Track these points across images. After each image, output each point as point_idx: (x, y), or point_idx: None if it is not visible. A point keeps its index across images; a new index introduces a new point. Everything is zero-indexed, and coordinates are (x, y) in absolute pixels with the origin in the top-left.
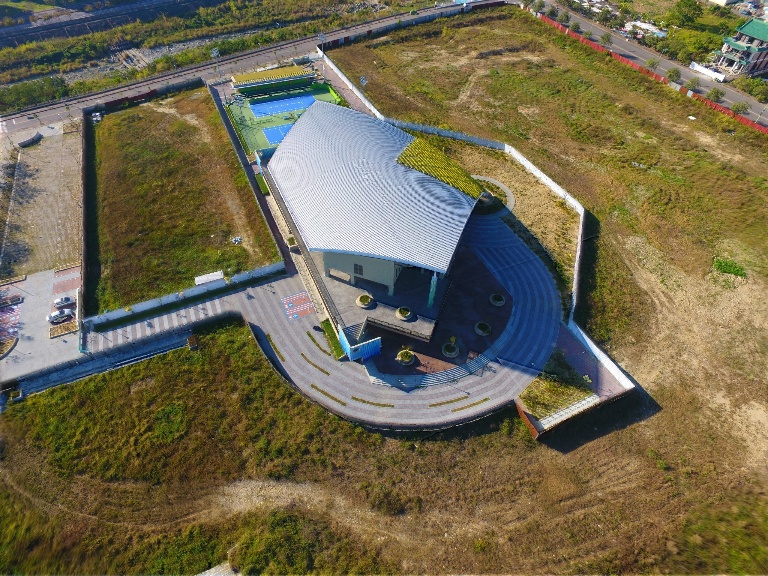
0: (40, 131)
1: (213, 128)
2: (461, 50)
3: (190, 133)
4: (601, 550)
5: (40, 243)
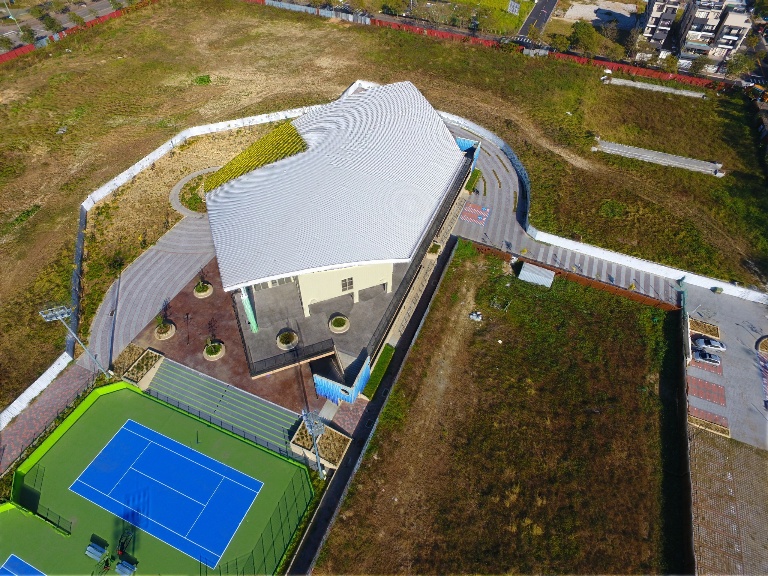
0: None
1: None
2: None
3: None
4: None
5: (767, 522)
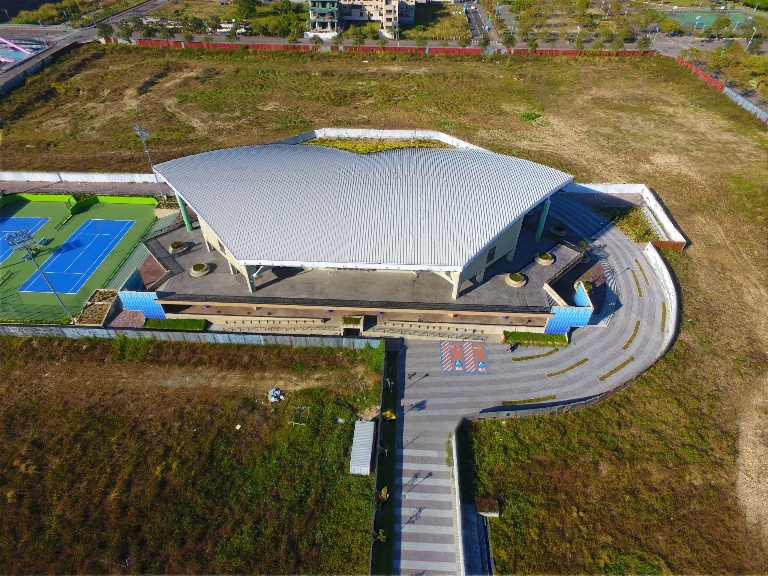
0: None
1: None
2: (109, 95)
3: None
4: None
5: None
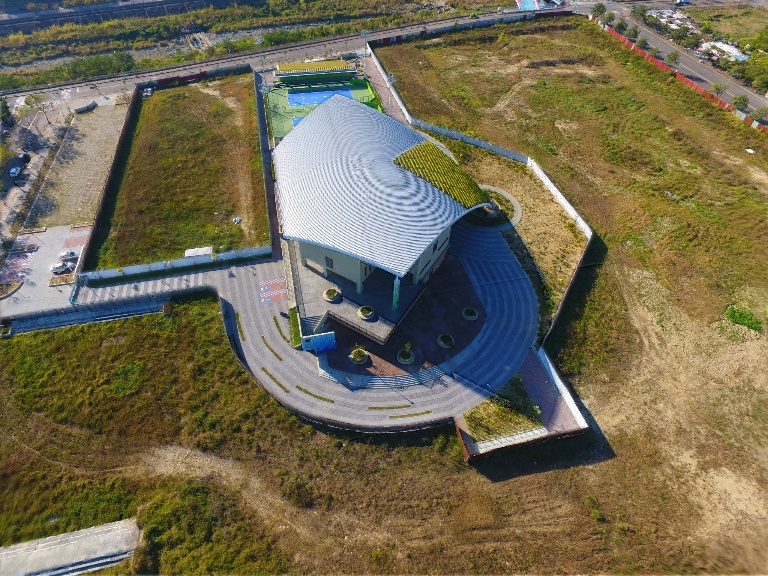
0: (97, 100)
1: (247, 112)
2: (513, 58)
3: (225, 115)
4: None
5: (67, 200)
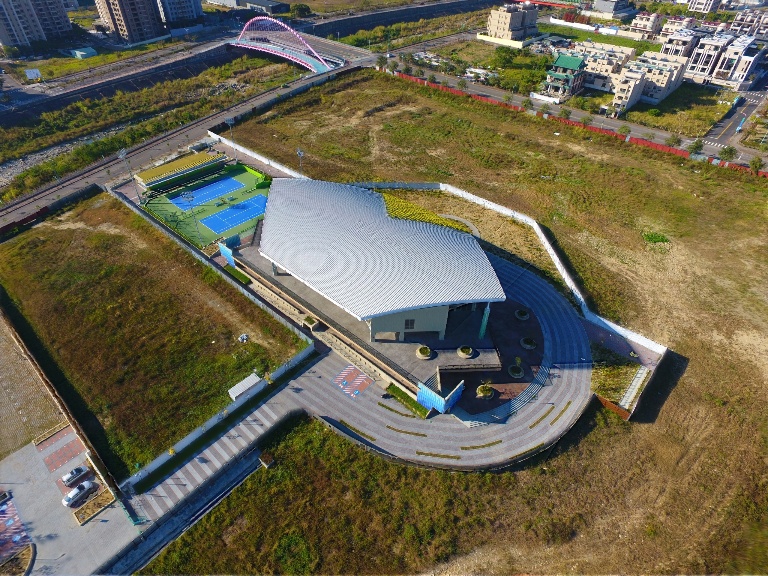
0: None
1: (142, 232)
2: (346, 112)
3: (117, 243)
4: (729, 489)
5: None
